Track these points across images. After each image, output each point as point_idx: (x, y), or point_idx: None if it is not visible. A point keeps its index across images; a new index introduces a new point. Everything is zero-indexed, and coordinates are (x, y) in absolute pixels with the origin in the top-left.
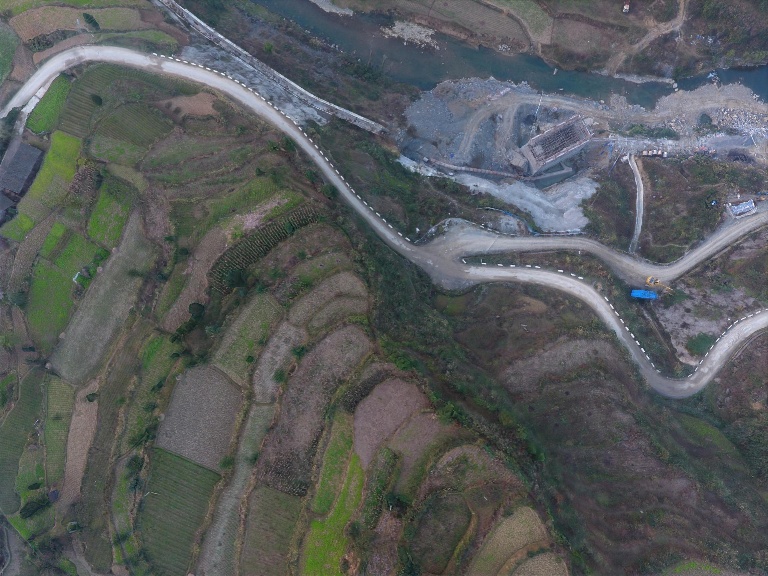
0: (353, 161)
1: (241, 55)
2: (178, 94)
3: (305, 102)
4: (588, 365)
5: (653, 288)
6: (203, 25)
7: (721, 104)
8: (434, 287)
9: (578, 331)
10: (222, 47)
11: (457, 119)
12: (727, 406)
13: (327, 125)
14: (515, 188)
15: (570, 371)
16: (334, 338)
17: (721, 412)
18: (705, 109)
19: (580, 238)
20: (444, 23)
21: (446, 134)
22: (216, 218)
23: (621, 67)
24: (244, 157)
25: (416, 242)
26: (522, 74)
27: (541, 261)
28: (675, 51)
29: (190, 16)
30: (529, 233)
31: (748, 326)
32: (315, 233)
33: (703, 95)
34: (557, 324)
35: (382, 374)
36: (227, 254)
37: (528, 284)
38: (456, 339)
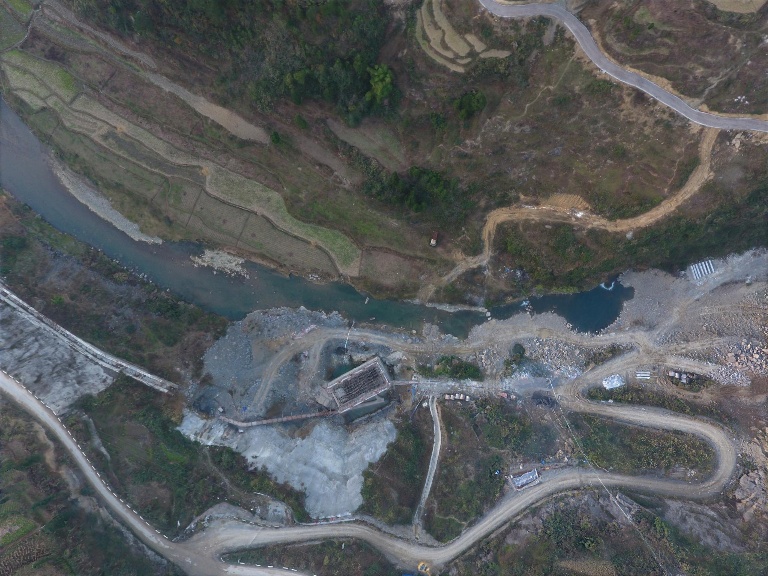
0: (127, 436)
1: None
2: None
3: (91, 359)
4: None
5: (426, 572)
6: None
7: (534, 334)
8: None
9: None
10: (8, 302)
11: (255, 364)
12: None
13: (110, 387)
14: (305, 446)
15: None
16: None
17: None
18: (517, 339)
19: (349, 524)
20: (252, 254)
21: (242, 382)
22: None
23: (432, 297)
24: None
25: (174, 540)
26: (334, 303)
27: (298, 563)
28: (483, 285)
29: None
30: (295, 523)
31: None
32: (37, 572)
33: (516, 325)
34: None
35: None
36: None
37: None
38: None
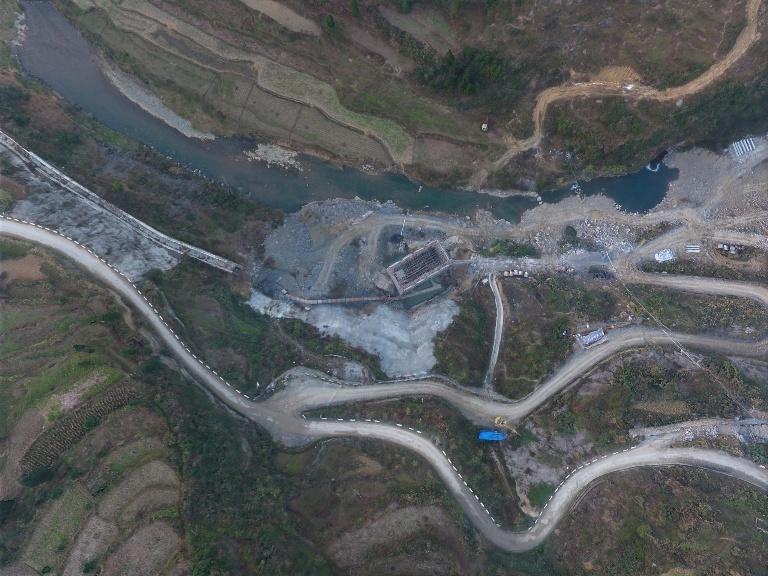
0: (198, 309)
1: (90, 195)
2: (4, 258)
3: (155, 242)
4: (417, 535)
5: (502, 427)
6: (48, 167)
7: (585, 216)
8: (274, 445)
9: (407, 498)
10: (69, 189)
11: (316, 248)
12: (565, 561)
13: (177, 267)
14: (372, 321)
15: (399, 541)
16: (141, 535)
17: (560, 567)
18: (569, 221)
19: (426, 382)
20: (306, 146)
21: (305, 264)
22: (34, 397)
23: (484, 183)
24: (68, 327)
25: (255, 399)
26: (387, 192)
27: (381, 414)
28: (535, 167)
29: (35, 158)
30: (373, 381)
31: (586, 475)
32: (130, 416)
33: (567, 207)
34: (390, 488)
35: (187, 575)
36: (40, 440)
37: (368, 439)
38: (289, 507)
